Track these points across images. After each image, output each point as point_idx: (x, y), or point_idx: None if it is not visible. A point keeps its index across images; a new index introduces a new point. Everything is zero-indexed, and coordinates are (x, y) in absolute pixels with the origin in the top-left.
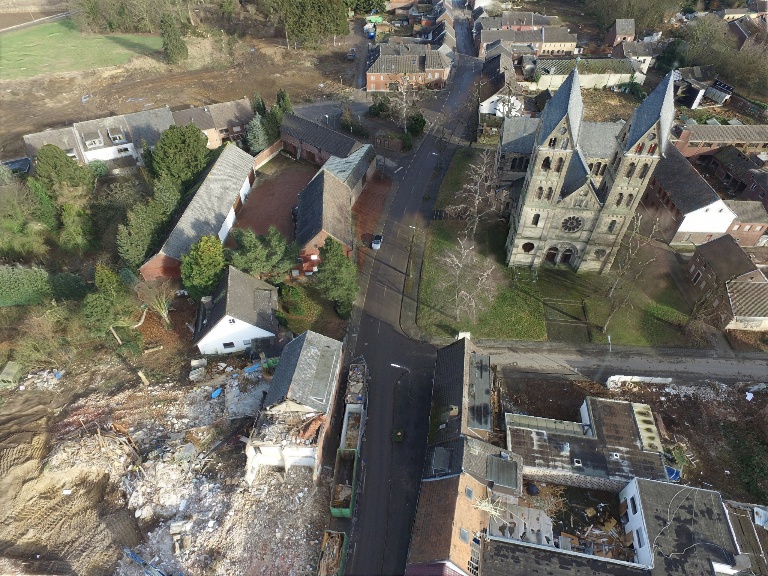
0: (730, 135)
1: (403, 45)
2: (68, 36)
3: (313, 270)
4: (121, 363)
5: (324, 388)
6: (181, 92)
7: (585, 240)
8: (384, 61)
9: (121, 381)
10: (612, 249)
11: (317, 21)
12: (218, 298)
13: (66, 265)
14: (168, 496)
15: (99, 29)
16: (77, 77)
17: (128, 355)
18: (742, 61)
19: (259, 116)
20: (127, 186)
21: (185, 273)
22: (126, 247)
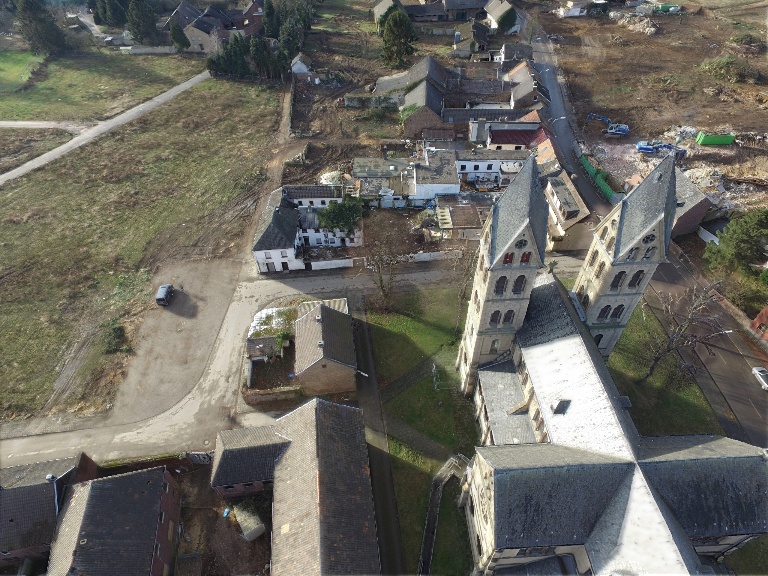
0: None
1: None
2: None
3: None
4: None
5: None
6: None
7: None
8: None
9: None
10: None
11: None
12: None
13: None
14: (691, 170)
15: None
16: None
17: None
18: None
19: None
20: None
21: None
22: None
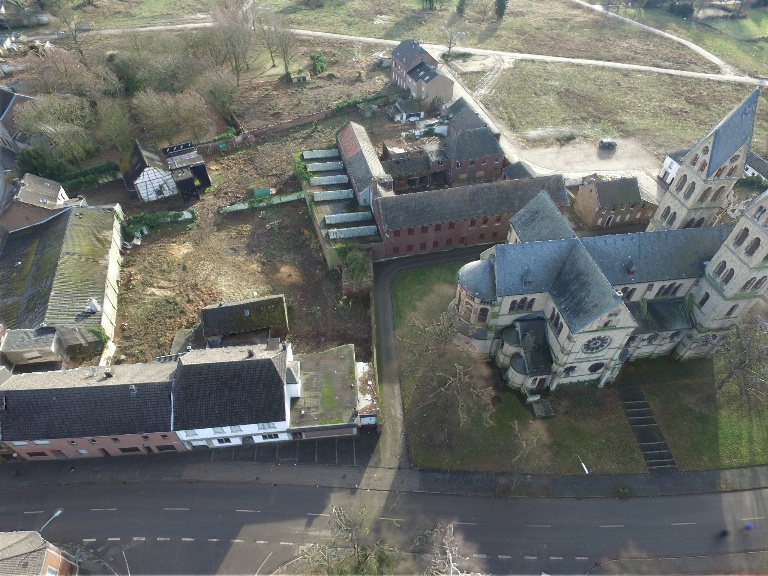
0: (373, 157)
1: None
2: None
3: None
4: None
5: None
6: None
7: None
8: None
9: None
10: None
11: None
12: None
13: None
14: None
15: None
16: None
17: None
18: (172, 115)
19: None
20: None
21: None
22: None
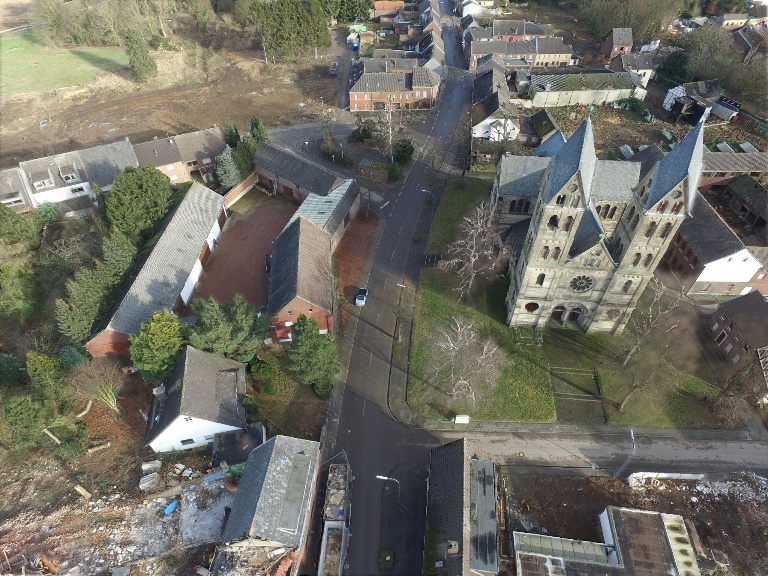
0: (745, 164)
1: (388, 59)
2: (30, 51)
3: (288, 336)
4: (60, 467)
5: (296, 514)
6: (149, 115)
7: (596, 300)
8: (368, 79)
9: (58, 492)
10: (627, 309)
11: (296, 33)
12: (173, 388)
13: (1, 340)
14: None
15: (63, 43)
16: (36, 99)
17: (69, 456)
18: (750, 76)
19: (230, 149)
20: (75, 241)
21: (135, 355)
22: (67, 323)
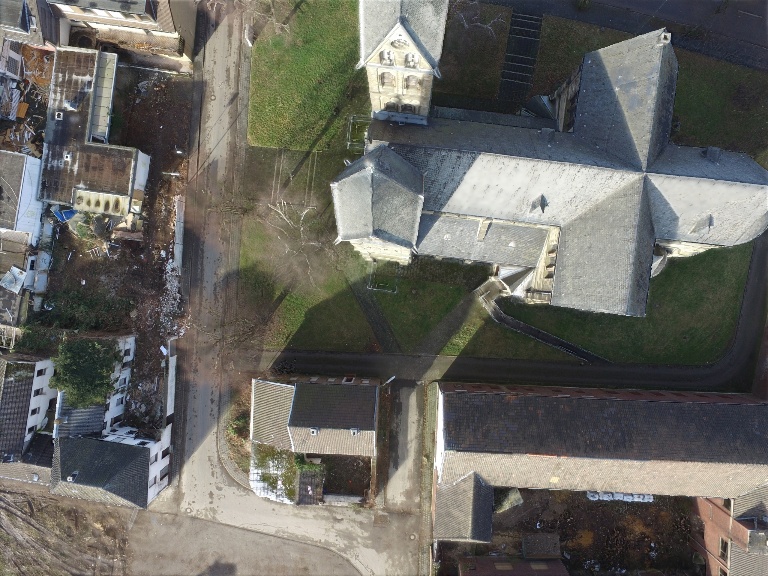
0: None
1: None
2: None
3: None
4: None
5: None
6: None
7: None
8: None
9: None
10: None
11: None
12: None
13: None
14: None
15: None
16: None
17: None
18: None
19: None
20: None
21: None
22: None
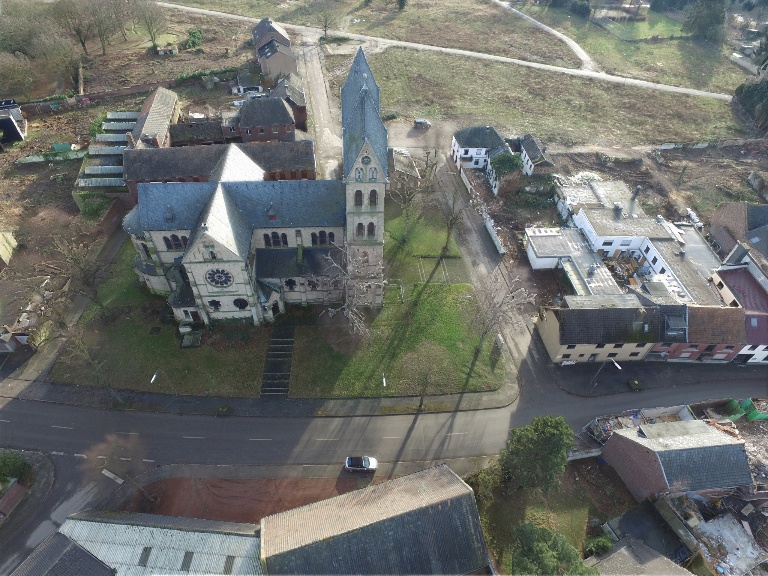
0: (162, 119)
1: None
2: None
3: None
4: None
5: (692, 423)
6: None
7: None
8: None
9: None
10: None
11: None
12: None
13: None
14: None
15: None
16: None
17: None
18: None
19: None
20: None
21: None
22: None
